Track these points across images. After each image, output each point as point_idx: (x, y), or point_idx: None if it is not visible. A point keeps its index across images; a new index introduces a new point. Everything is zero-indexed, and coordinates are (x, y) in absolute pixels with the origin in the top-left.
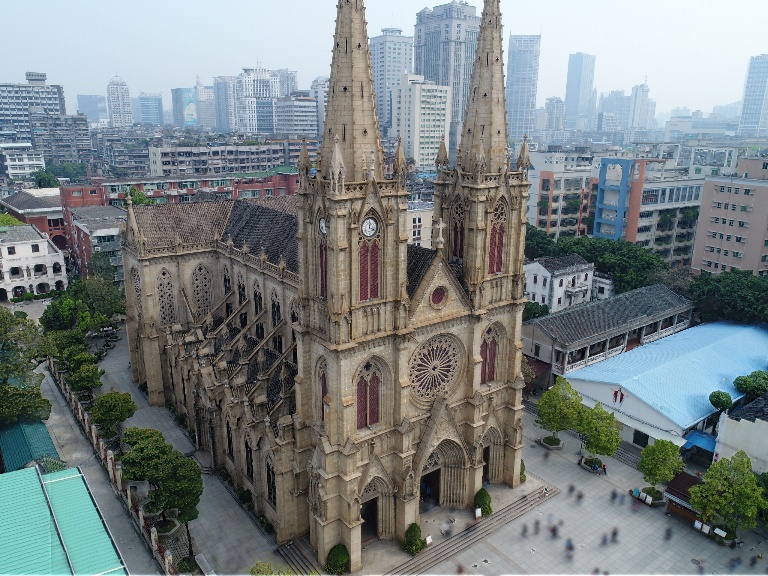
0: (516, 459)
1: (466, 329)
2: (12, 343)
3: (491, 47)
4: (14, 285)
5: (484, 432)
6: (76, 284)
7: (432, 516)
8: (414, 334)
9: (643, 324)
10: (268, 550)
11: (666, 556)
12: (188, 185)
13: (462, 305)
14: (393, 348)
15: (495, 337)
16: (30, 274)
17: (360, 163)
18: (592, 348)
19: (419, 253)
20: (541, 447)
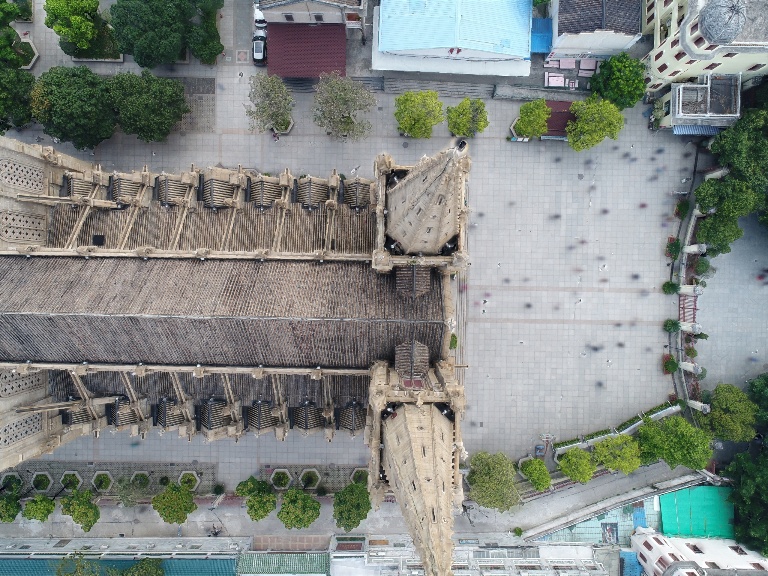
0: None
1: None
2: None
3: None
4: None
5: None
6: None
7: None
8: None
9: None
10: None
11: (564, 189)
12: None
13: None
14: None
15: None
16: None
17: None
18: None
19: (418, 326)
20: (412, 140)
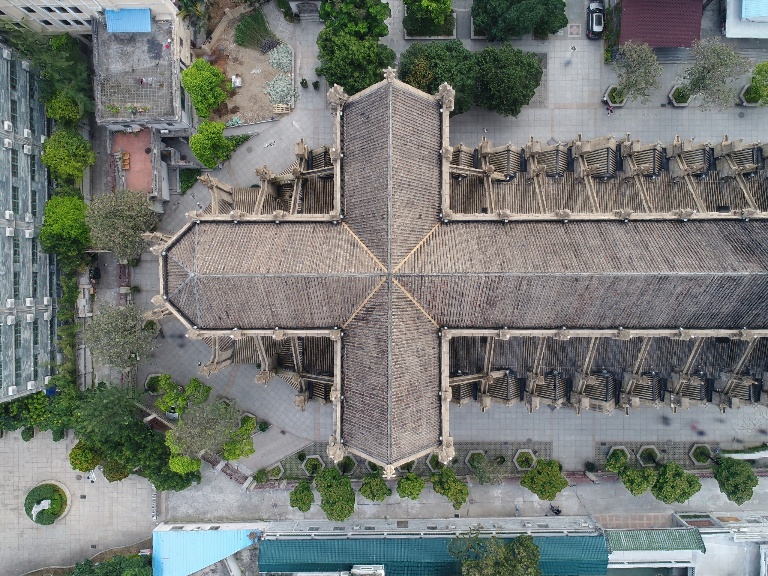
0: None
1: None
2: None
3: None
4: None
5: None
6: (3, 418)
7: None
8: None
9: None
10: None
11: None
12: None
13: None
14: None
15: None
16: None
17: None
18: None
19: None
20: (748, 110)
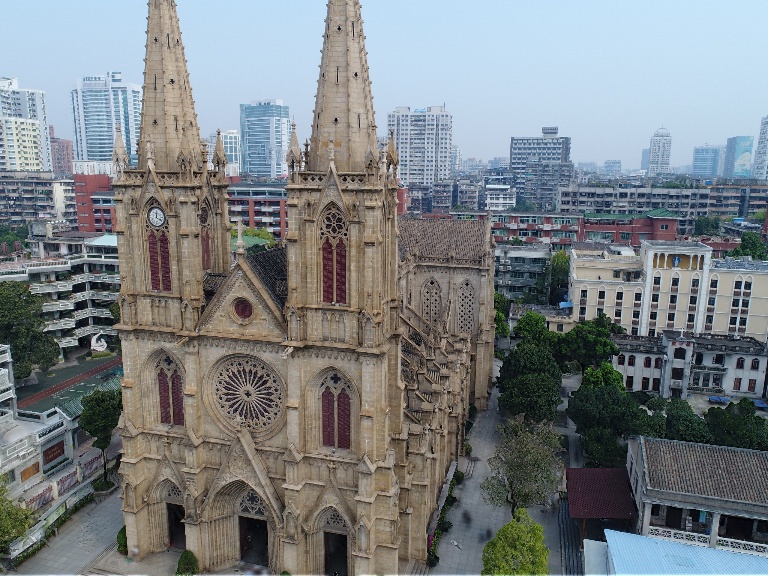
0: (358, 570)
1: (286, 361)
2: None
3: None
4: None
5: (321, 508)
6: None
7: (248, 570)
8: (210, 343)
9: None
10: None
11: None
12: (530, 220)
13: (278, 329)
14: None
15: (347, 390)
16: None
17: None
18: (766, 530)
19: None
20: None
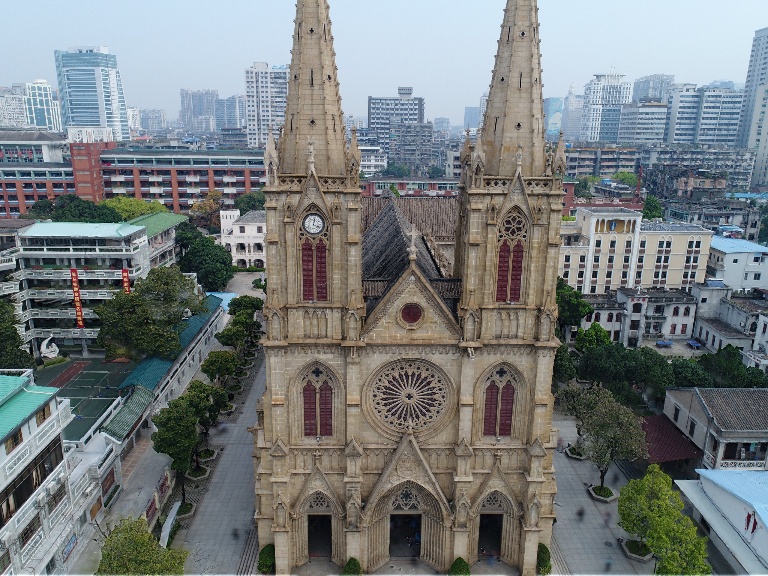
0: (528, 543)
1: (455, 361)
2: (169, 294)
3: (514, 19)
4: None
5: (484, 493)
6: None
7: (402, 564)
8: (373, 350)
9: None
10: (245, 526)
11: None
12: (447, 187)
13: (449, 331)
14: (345, 360)
15: (512, 382)
16: None
17: (304, 155)
18: None
19: (405, 262)
20: (618, 549)
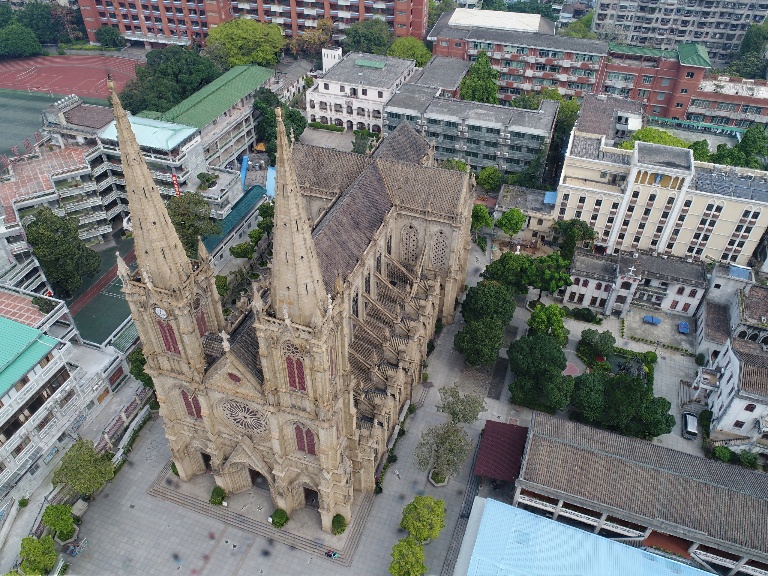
0: (323, 516)
1: None
2: None
3: None
4: (358, 120)
5: (299, 480)
6: None
7: (257, 494)
8: (214, 390)
9: (690, 538)
10: None
11: None
12: (550, 54)
13: (260, 394)
14: None
15: None
16: (370, 115)
17: (146, 271)
18: None
19: None
20: None
